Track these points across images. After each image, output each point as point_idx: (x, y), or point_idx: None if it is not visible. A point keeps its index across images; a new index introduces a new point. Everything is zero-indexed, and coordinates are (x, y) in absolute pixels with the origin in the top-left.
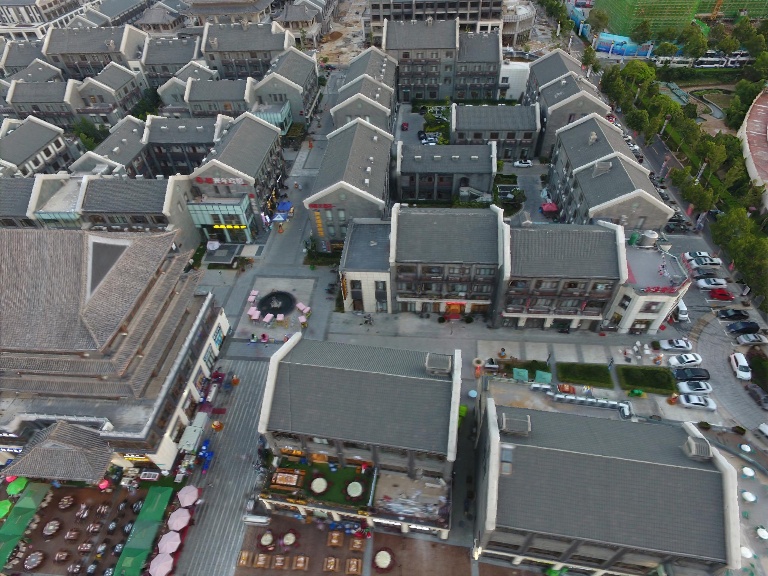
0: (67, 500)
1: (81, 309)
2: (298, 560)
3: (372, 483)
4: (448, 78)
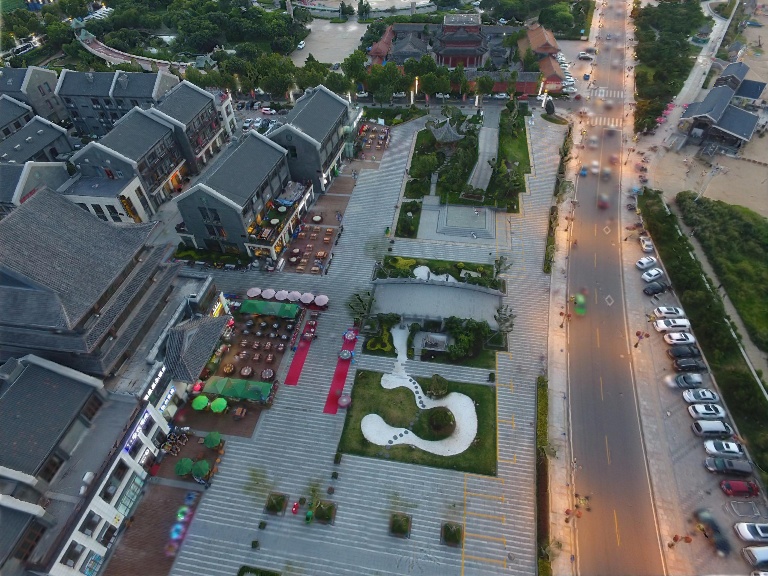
0: (227, 368)
1: None
2: (308, 246)
3: None
4: None
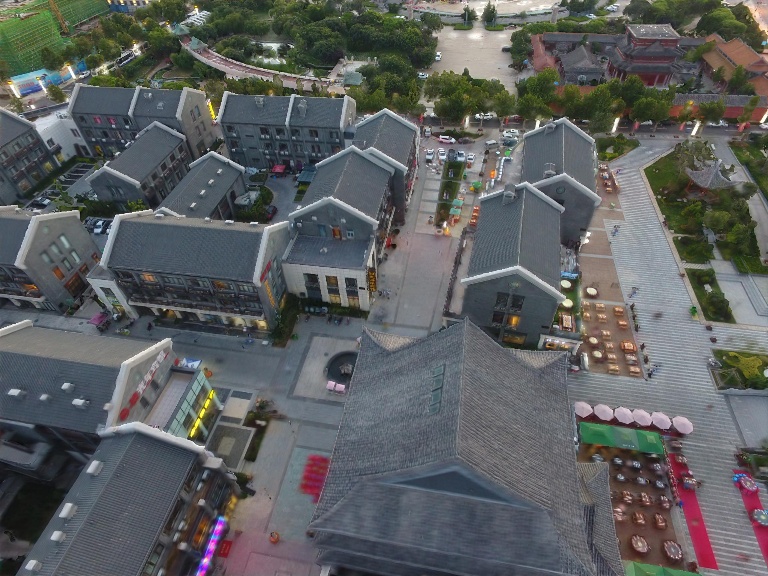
0: None
1: (529, 366)
2: (606, 334)
3: (562, 273)
4: None
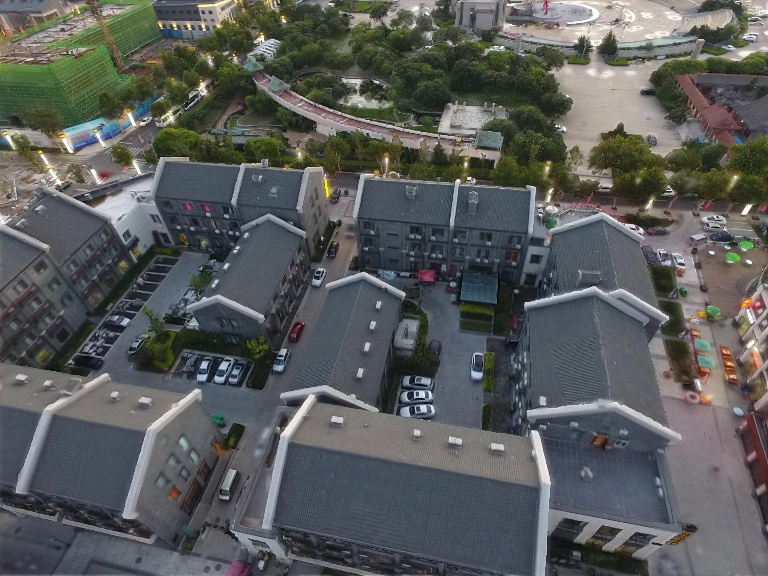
0: None
1: None
2: None
3: None
4: (63, 296)
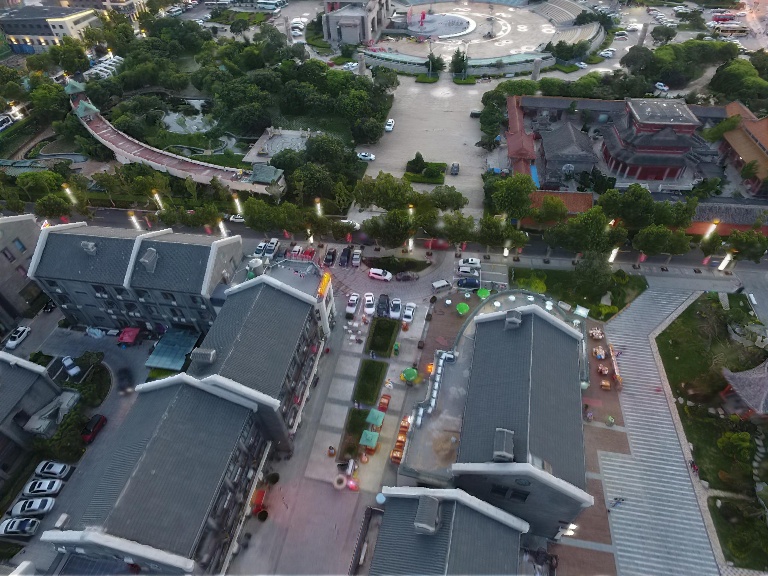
0: None
1: None
2: None
3: None
4: None
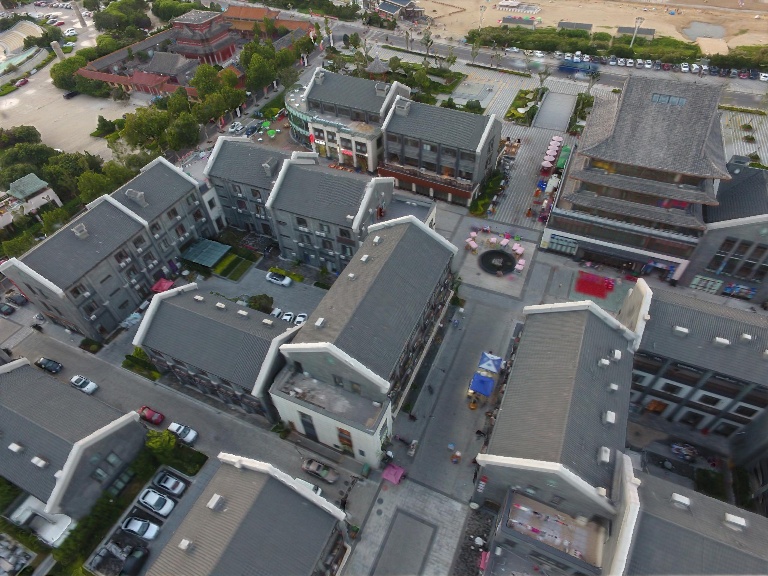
0: None
1: None
2: None
3: None
4: None
